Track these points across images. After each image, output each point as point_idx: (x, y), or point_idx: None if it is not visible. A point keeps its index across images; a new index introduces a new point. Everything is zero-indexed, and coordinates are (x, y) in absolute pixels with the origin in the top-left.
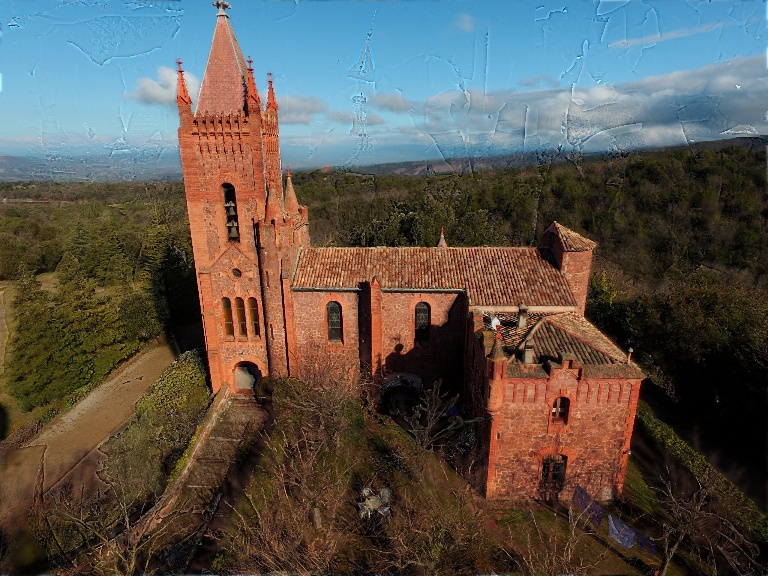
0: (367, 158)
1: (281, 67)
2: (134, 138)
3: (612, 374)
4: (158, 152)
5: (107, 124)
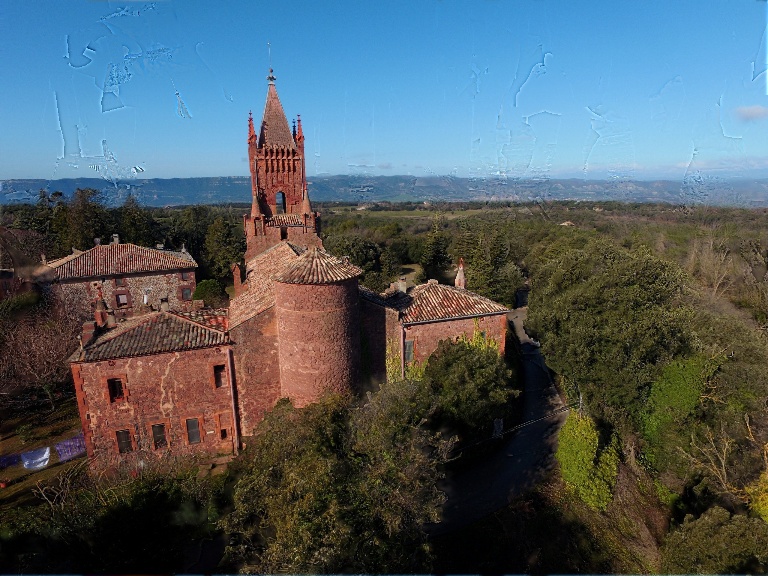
0: (740, 177)
1: (675, 68)
2: None
3: None
4: (457, 174)
5: (538, 151)
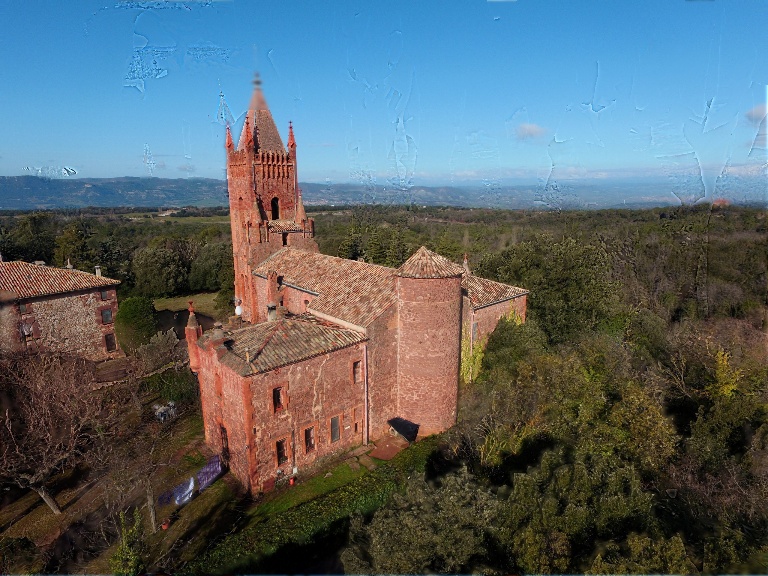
0: (583, 186)
1: (523, 100)
2: (390, 170)
3: (231, 364)
4: None
5: None
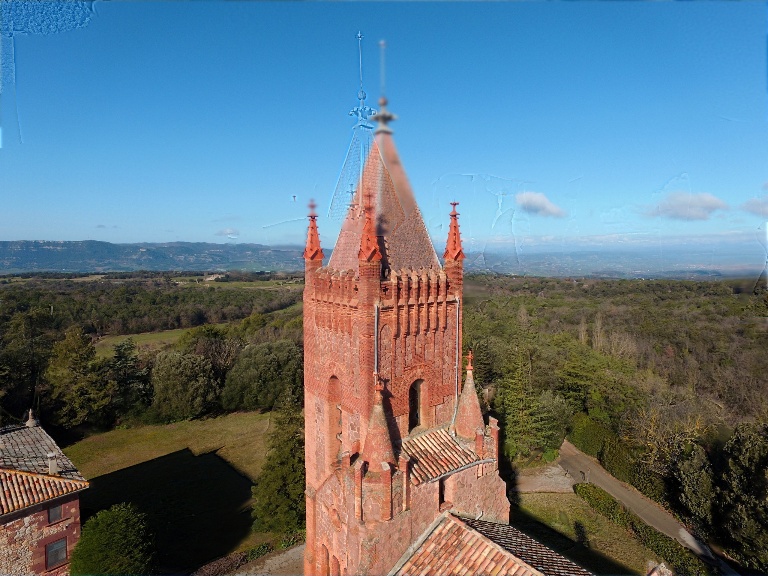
0: None
1: (682, 165)
2: (490, 255)
3: None
4: None
5: None
